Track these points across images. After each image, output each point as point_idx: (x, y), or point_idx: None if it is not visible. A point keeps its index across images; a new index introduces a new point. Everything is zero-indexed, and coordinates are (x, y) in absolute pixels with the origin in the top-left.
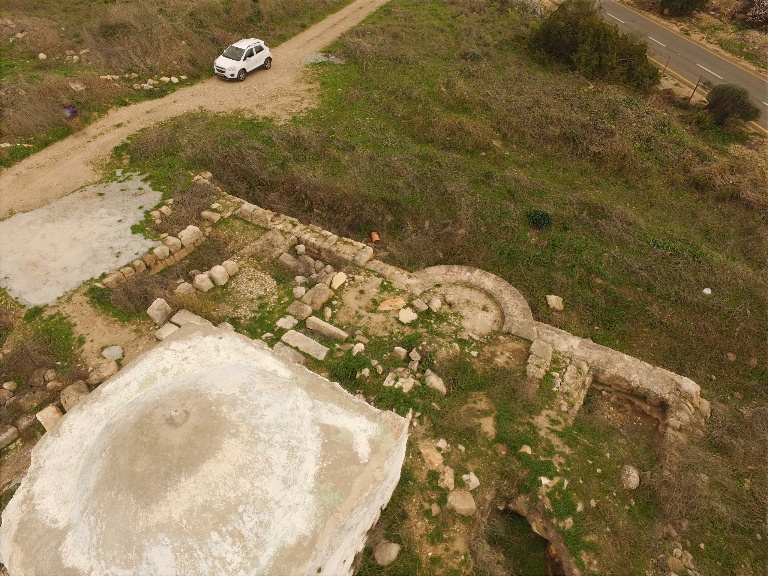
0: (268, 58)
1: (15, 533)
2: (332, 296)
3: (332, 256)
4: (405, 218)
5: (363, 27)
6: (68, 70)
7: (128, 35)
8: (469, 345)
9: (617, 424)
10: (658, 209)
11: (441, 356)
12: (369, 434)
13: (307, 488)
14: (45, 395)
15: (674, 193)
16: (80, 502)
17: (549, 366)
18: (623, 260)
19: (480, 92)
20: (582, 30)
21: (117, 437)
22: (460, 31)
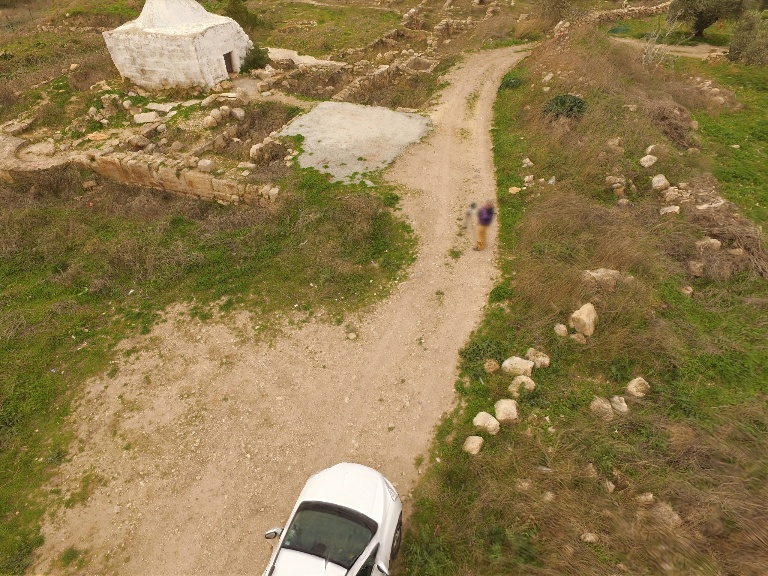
0: None
1: None
2: None
3: None
4: None
5: None
6: None
7: None
8: None
9: None
10: None
11: None
12: None
13: None
14: None
15: None
16: None
17: None
18: None
19: None
20: None
21: None
22: None
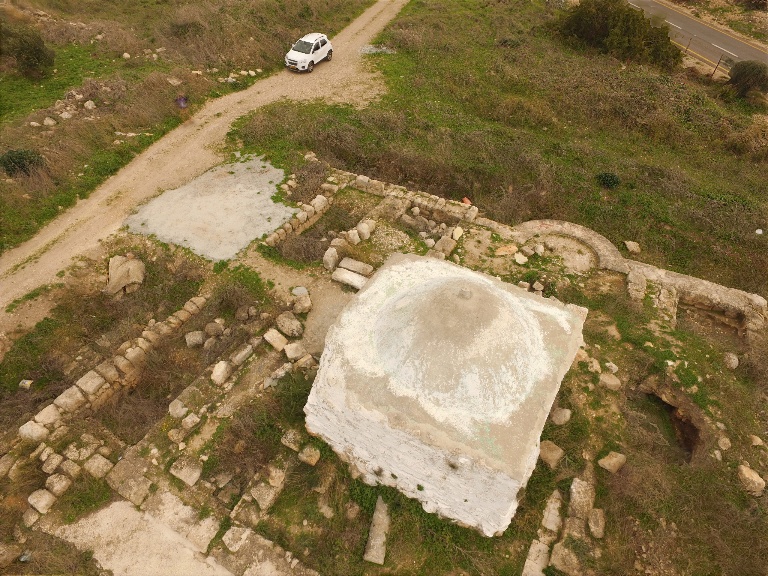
0: (330, 51)
1: (345, 384)
2: (456, 245)
3: (443, 216)
4: (491, 185)
5: (405, 19)
6: (153, 67)
7: (198, 33)
8: (576, 279)
9: (703, 333)
10: (705, 169)
11: (560, 286)
12: (565, 317)
13: (541, 347)
14: (263, 322)
15: (715, 156)
16: (397, 356)
17: (646, 290)
18: (686, 210)
19: (527, 75)
20: (612, 16)
21: (421, 311)
22: (493, 20)
